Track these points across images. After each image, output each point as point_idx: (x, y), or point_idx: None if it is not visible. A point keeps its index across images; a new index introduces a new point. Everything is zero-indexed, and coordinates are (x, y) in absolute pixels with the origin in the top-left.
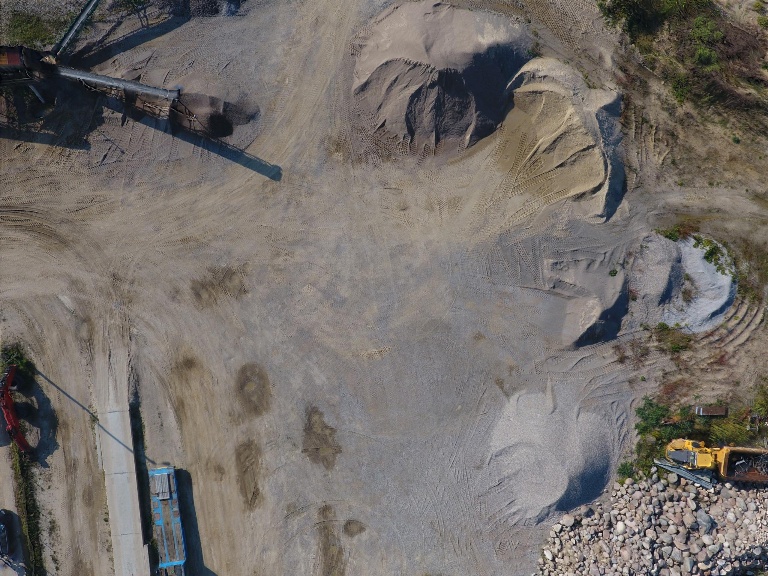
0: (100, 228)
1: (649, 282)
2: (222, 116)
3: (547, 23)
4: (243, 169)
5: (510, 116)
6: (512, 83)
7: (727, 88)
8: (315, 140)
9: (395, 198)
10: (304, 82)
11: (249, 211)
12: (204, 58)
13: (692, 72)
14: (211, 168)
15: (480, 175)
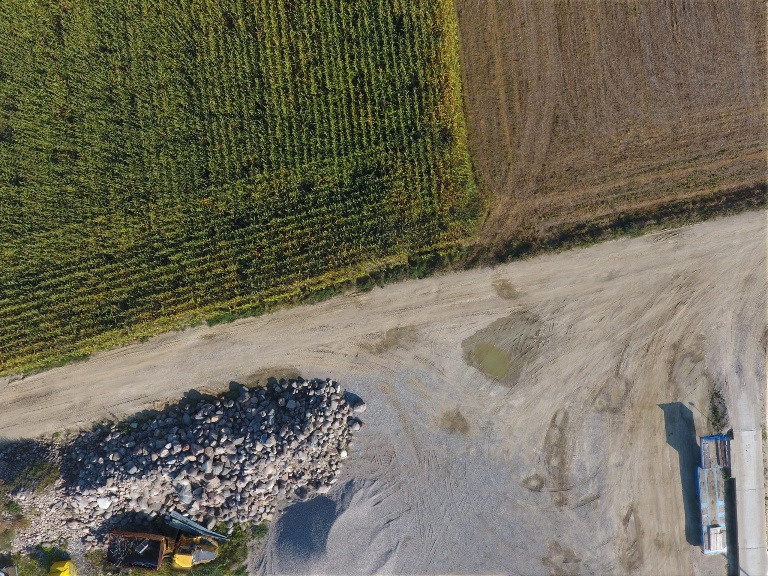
0: None
1: None
2: None
3: None
4: None
5: None
6: None
7: None
8: None
9: None
10: None
11: None
12: None
13: None
14: None
15: None
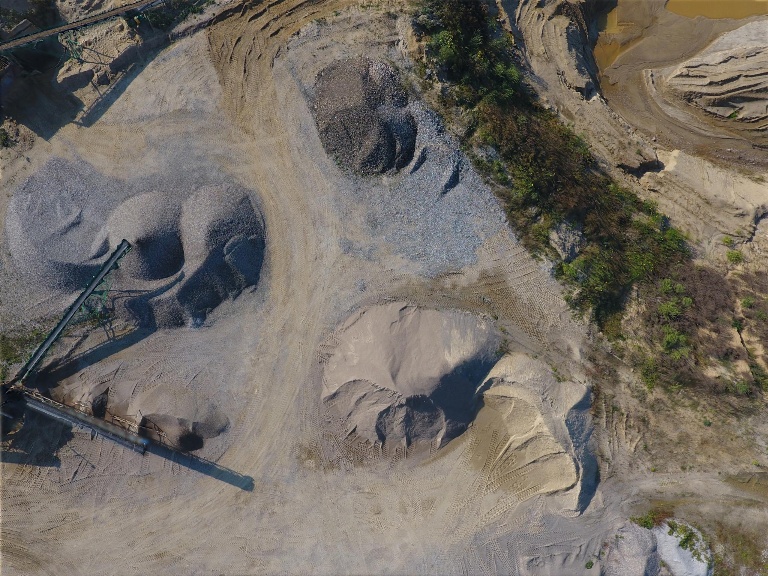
0: (73, 547)
1: (625, 574)
2: (192, 433)
3: (514, 318)
4: (215, 481)
5: (481, 415)
6: (481, 387)
7: (696, 378)
8: (286, 449)
9: (369, 502)
10: (273, 392)
11: (223, 523)
12: (172, 370)
13: (661, 359)
14: (183, 482)
15: (453, 475)
